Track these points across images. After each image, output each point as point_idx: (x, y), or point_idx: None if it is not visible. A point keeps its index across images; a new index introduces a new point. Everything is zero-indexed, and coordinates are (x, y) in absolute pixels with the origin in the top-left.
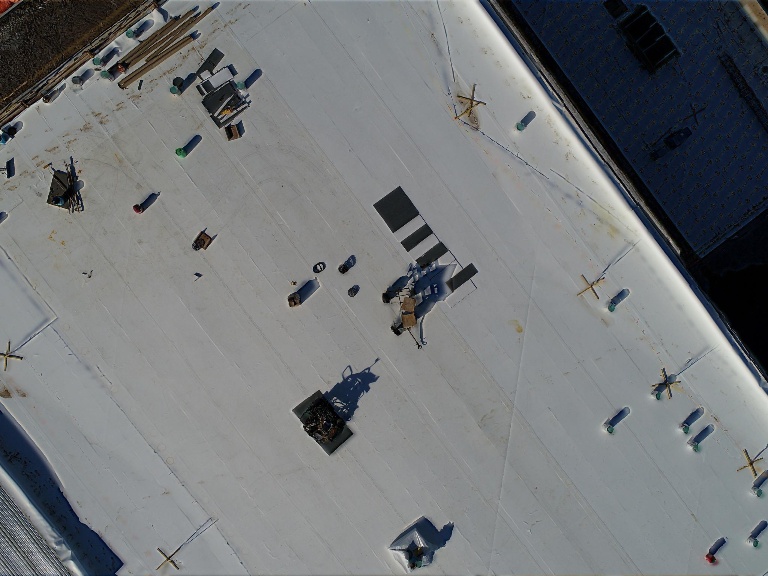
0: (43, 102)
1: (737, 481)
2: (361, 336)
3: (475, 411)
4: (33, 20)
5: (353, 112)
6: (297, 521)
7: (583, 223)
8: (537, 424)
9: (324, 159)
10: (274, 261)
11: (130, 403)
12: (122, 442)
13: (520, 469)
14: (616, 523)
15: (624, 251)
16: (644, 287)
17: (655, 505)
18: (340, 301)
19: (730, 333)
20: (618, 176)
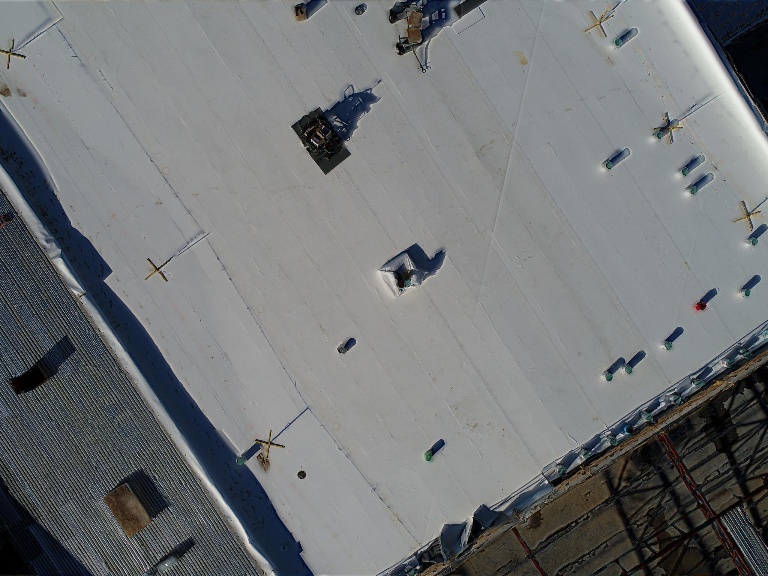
0: None
1: (733, 232)
2: (365, 56)
3: (475, 141)
4: None
5: None
6: (289, 240)
7: None
8: (536, 159)
9: None
10: None
11: (130, 110)
12: (119, 149)
13: (516, 203)
14: (608, 265)
15: None
16: (653, 28)
17: (649, 250)
18: (347, 19)
19: (736, 75)
20: None
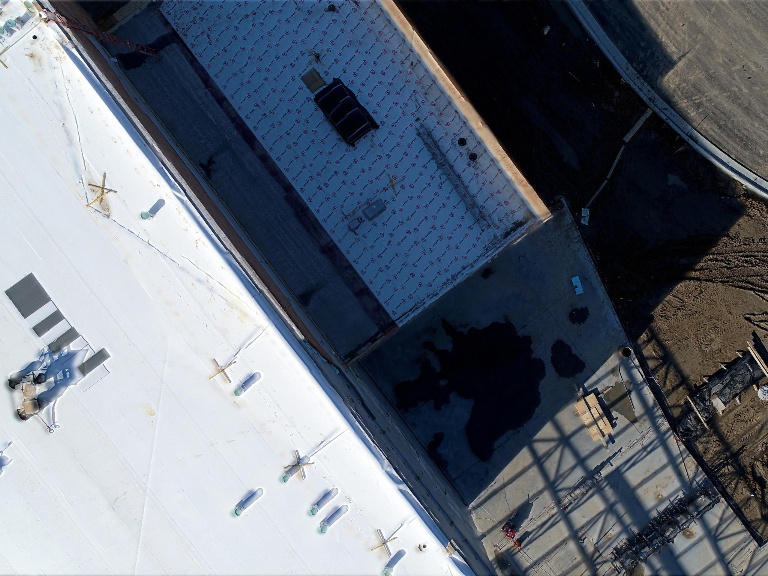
0: None
1: (371, 560)
2: None
3: (108, 493)
4: None
5: None
6: None
7: (214, 308)
8: (171, 505)
9: None
10: None
11: None
12: None
13: (154, 550)
14: None
15: (254, 336)
16: (275, 371)
17: None
18: None
19: (354, 417)
20: (241, 264)
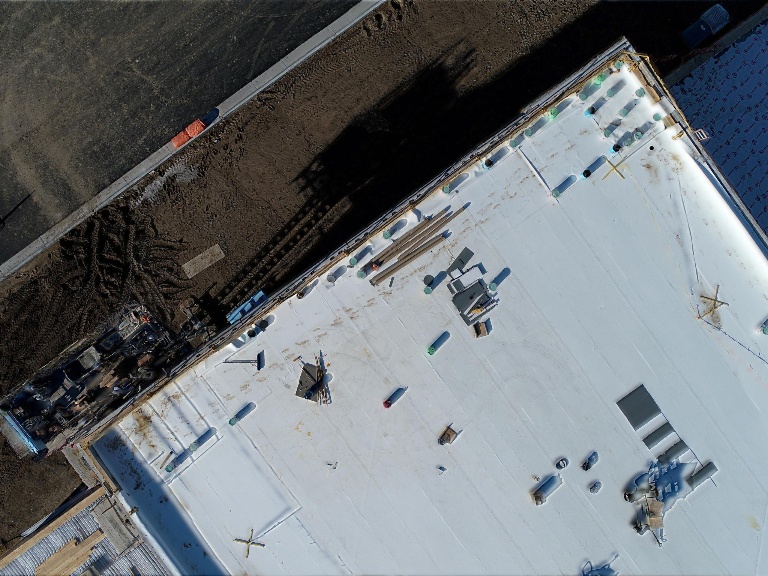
0: (295, 297)
1: None
2: (601, 532)
3: None
4: (208, 153)
5: (598, 311)
6: None
7: None
8: None
9: (569, 357)
10: (518, 457)
11: None
12: None
13: None
14: None
15: None
16: None
17: None
18: (582, 497)
19: None
20: None
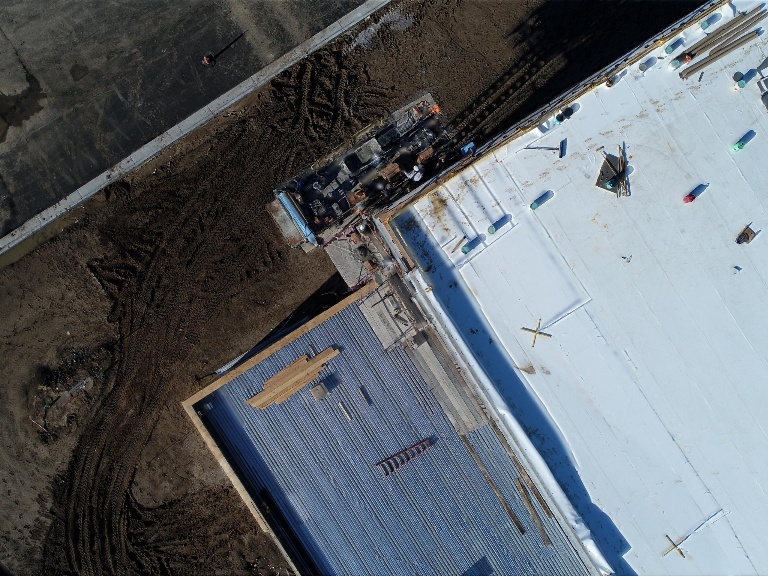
0: (603, 86)
1: None
2: None
3: None
4: (425, 2)
5: None
6: None
7: None
8: None
9: None
10: None
11: (653, 389)
12: (640, 427)
13: None
14: None
15: None
16: None
17: None
18: None
19: None
20: None
